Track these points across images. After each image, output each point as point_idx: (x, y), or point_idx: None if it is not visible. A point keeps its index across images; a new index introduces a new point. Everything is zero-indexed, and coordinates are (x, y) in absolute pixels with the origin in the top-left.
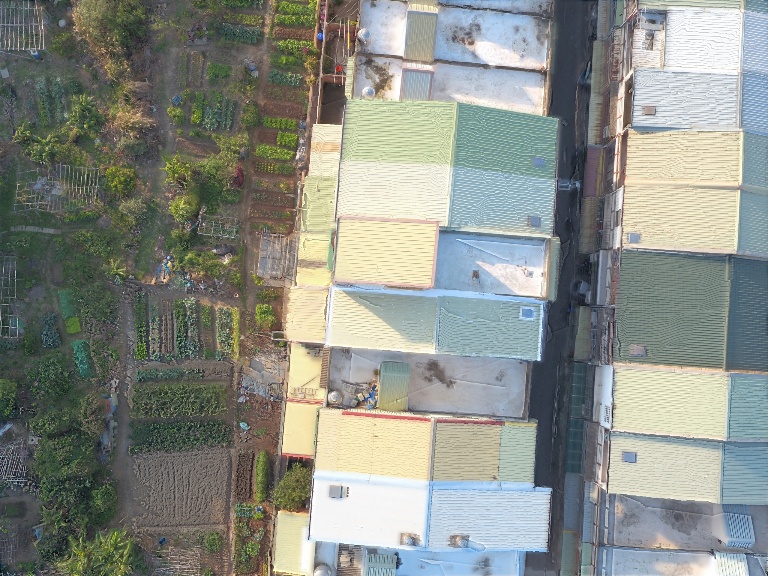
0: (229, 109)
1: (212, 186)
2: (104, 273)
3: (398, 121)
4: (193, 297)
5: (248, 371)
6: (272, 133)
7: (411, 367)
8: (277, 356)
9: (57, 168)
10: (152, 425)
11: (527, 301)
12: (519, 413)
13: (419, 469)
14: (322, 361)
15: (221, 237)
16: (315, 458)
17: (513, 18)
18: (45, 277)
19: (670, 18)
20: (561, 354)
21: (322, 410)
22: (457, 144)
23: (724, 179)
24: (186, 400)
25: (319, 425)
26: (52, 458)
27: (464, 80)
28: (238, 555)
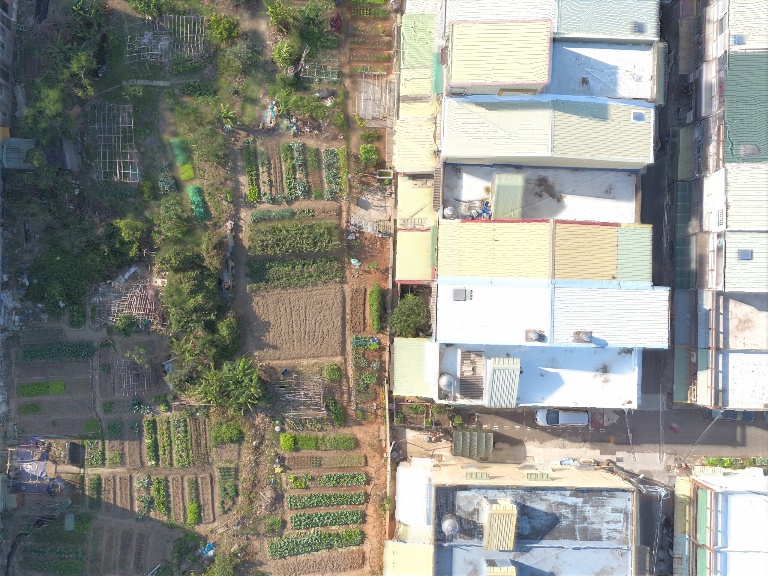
0: None
1: (311, 32)
2: (214, 120)
3: None
4: (299, 140)
5: (356, 210)
6: None
7: None
8: (383, 194)
9: (165, 18)
10: (268, 263)
11: (638, 104)
12: None
13: (540, 269)
14: (434, 182)
15: (323, 82)
16: (437, 266)
17: None
18: (158, 128)
19: None
20: (661, 183)
21: (441, 220)
22: None
23: None
24: (300, 236)
25: (439, 234)
26: (179, 292)
27: None
28: (356, 384)
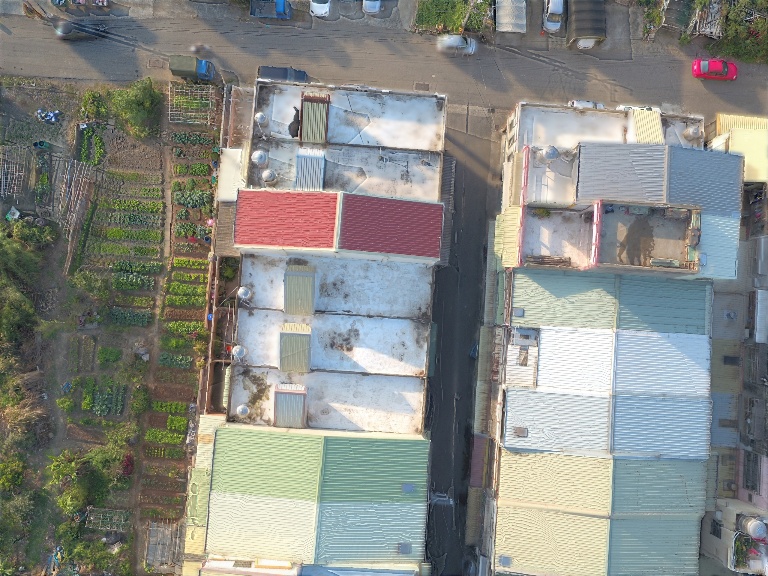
0: (120, 394)
1: (102, 474)
2: None
3: (261, 466)
4: None
5: None
6: (162, 417)
7: None
8: None
9: None
10: None
11: None
12: None
13: None
14: None
15: None
16: None
17: (392, 322)
18: None
19: (543, 337)
20: None
21: None
22: (324, 479)
23: (594, 507)
24: None
25: None
26: None
27: (342, 387)
28: None
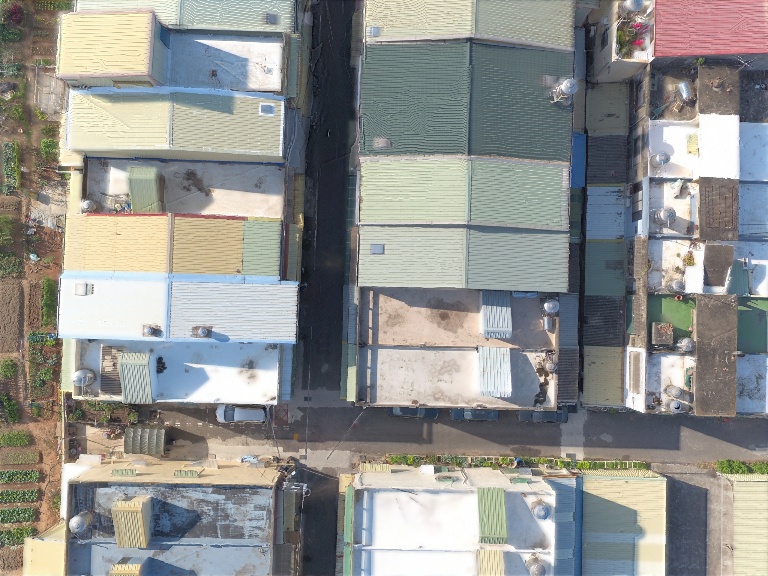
0: None
1: None
2: None
3: None
4: None
5: (36, 204)
6: None
7: (169, 177)
8: (64, 189)
9: None
10: None
11: (266, 97)
12: None
13: (159, 263)
14: None
15: (5, 75)
16: (63, 260)
17: None
18: None
19: None
20: None
21: (69, 214)
22: None
23: None
24: None
25: (66, 228)
26: None
27: None
28: (32, 381)
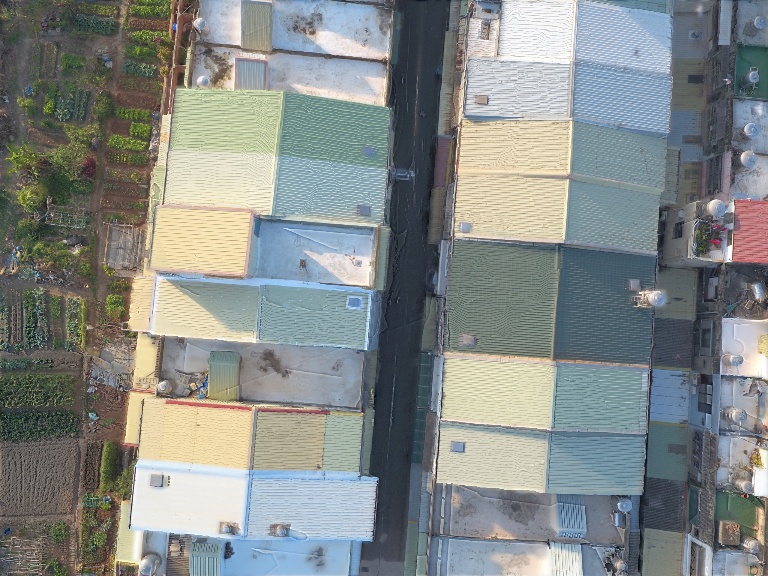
0: (82, 100)
1: (63, 176)
2: None
3: (218, 110)
4: (42, 287)
5: (98, 361)
6: (125, 124)
7: (246, 357)
8: (127, 346)
9: None
10: None
11: (354, 290)
12: (355, 403)
13: (240, 458)
14: None
15: (72, 227)
16: (139, 447)
17: (355, 8)
18: None
19: (504, 7)
20: (417, 345)
21: (147, 399)
22: (283, 133)
23: (553, 168)
24: (31, 390)
25: (143, 414)
26: None
27: (305, 70)
28: (85, 545)
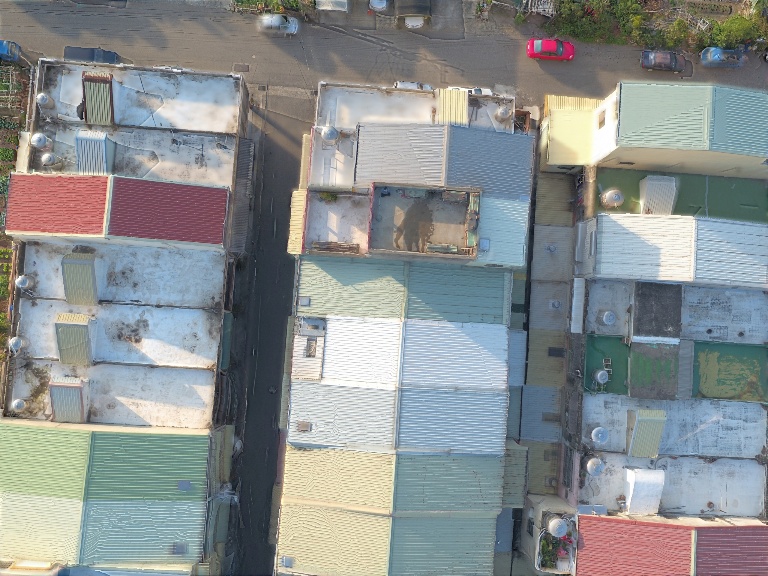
0: None
1: None
2: None
3: (18, 463)
4: None
5: None
6: None
7: None
8: None
9: None
10: None
11: None
12: None
13: None
14: None
15: None
16: None
17: (184, 312)
18: None
19: (329, 327)
20: None
21: None
22: (91, 476)
23: (376, 505)
24: None
25: None
26: None
27: (130, 380)
28: None
